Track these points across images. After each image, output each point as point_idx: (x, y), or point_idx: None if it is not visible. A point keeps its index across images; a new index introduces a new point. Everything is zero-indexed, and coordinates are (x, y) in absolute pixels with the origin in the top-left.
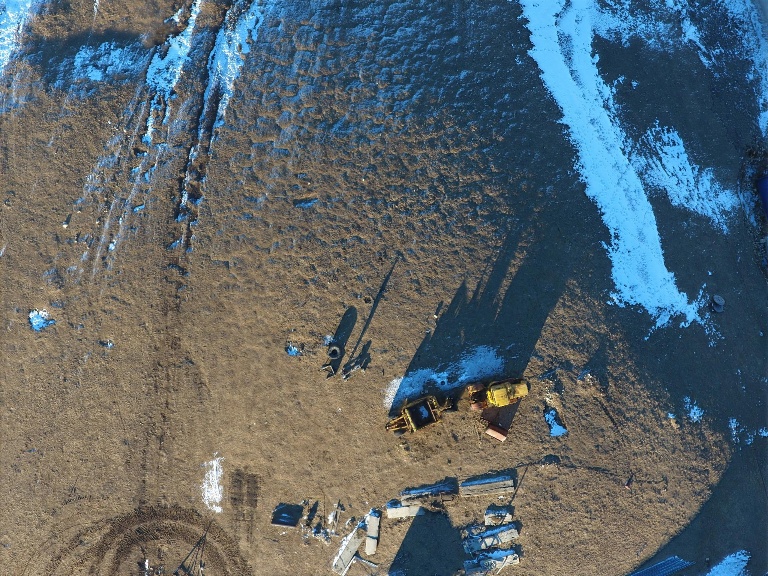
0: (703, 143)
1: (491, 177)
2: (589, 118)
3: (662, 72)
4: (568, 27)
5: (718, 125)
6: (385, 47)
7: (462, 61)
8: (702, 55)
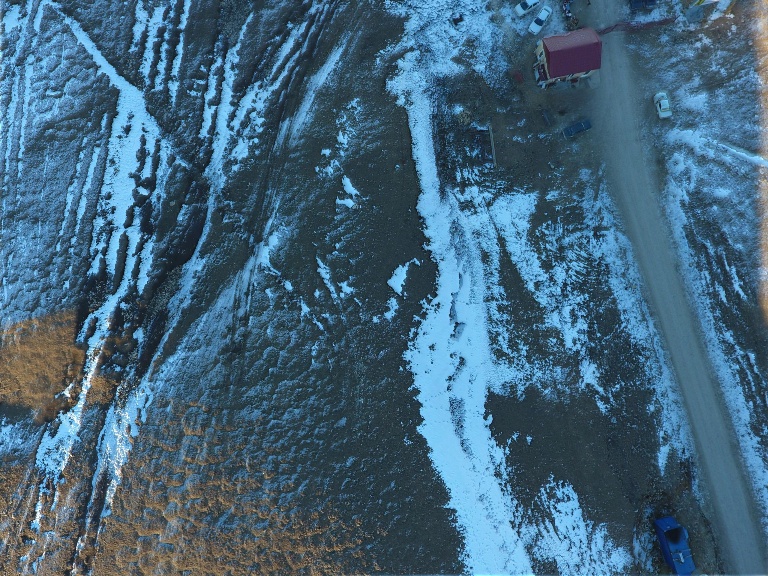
0: (598, 497)
1: None
2: (478, 495)
3: (558, 424)
4: (461, 390)
5: (613, 478)
6: (273, 432)
7: (349, 446)
8: (599, 400)
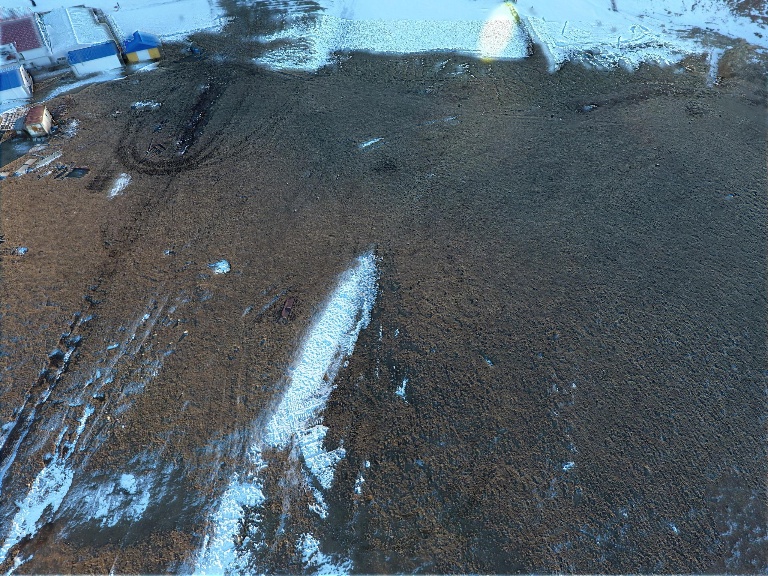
0: None
1: None
2: None
3: None
4: None
5: None
6: None
7: None
8: None
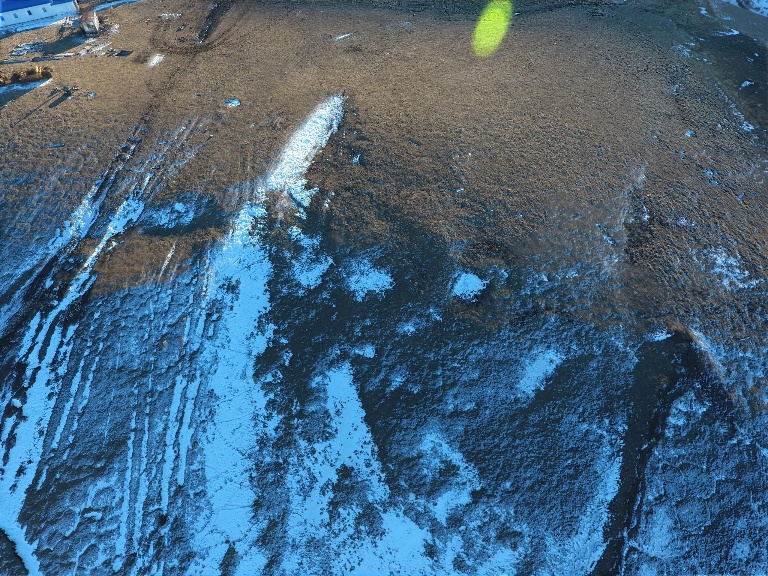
0: None
1: None
2: None
3: None
4: None
5: None
6: None
7: None
8: None
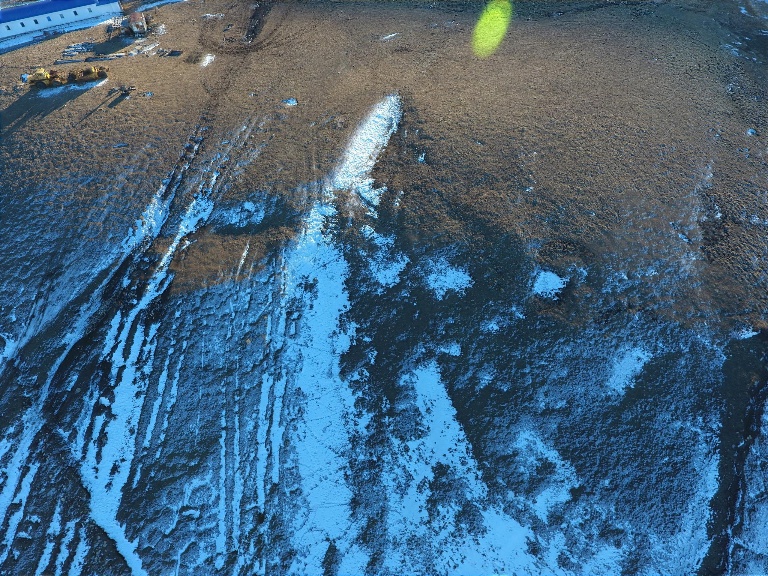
0: None
1: (3, 161)
2: None
3: None
4: None
5: None
6: (39, 226)
7: None
8: None
